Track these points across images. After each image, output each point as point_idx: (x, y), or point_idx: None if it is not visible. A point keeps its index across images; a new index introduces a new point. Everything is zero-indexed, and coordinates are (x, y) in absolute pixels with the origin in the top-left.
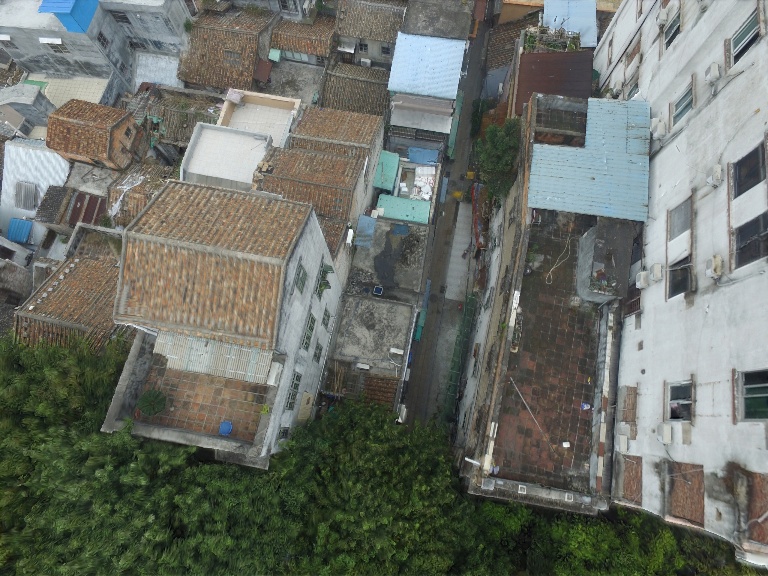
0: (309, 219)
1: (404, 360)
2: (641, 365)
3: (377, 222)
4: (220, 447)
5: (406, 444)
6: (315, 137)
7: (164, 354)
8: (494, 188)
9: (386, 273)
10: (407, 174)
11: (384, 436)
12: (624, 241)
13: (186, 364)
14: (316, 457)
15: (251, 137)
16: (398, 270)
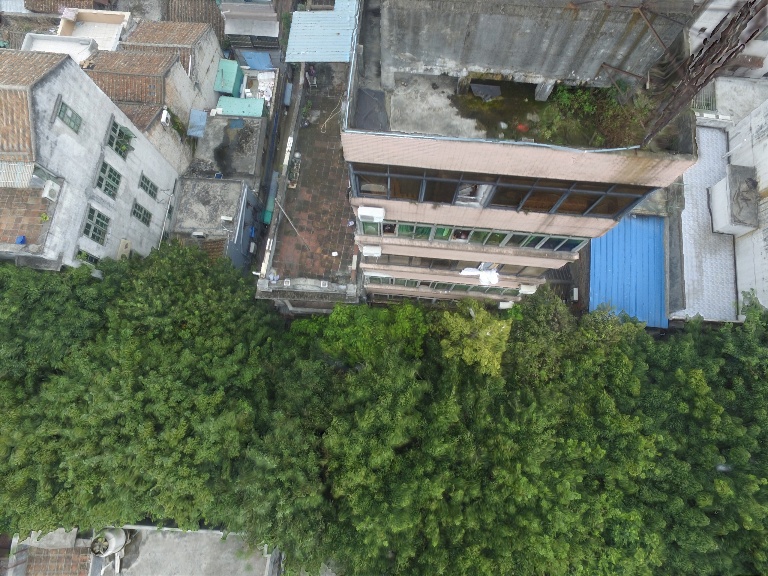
0: (66, 65)
1: (234, 225)
2: None
3: (216, 119)
4: (9, 249)
5: (205, 268)
6: (143, 43)
7: None
8: None
9: (225, 161)
10: (253, 82)
11: (183, 261)
12: None
13: None
14: (119, 276)
15: (77, 43)
16: (235, 158)
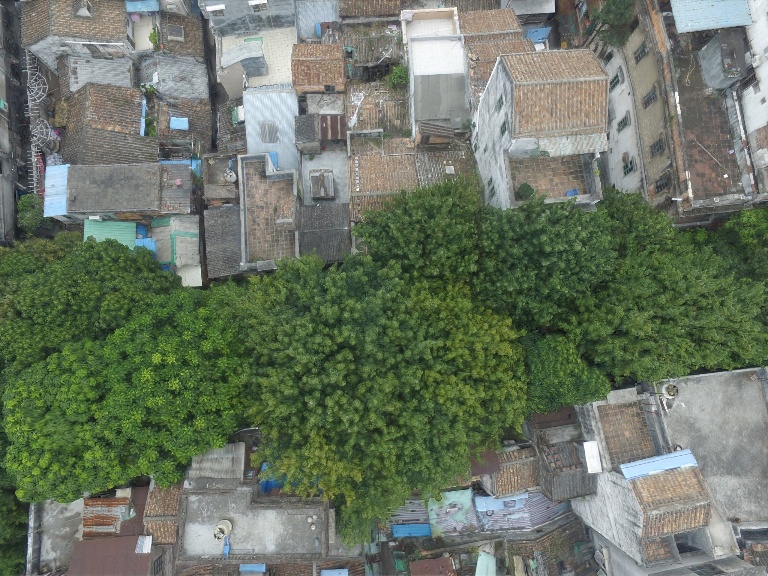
0: None
1: None
2: (767, 111)
3: None
4: (580, 199)
5: None
6: (480, 33)
7: (546, 150)
8: (613, 40)
9: None
10: None
11: None
12: (738, 42)
13: (560, 153)
14: None
15: (447, 40)
16: None
